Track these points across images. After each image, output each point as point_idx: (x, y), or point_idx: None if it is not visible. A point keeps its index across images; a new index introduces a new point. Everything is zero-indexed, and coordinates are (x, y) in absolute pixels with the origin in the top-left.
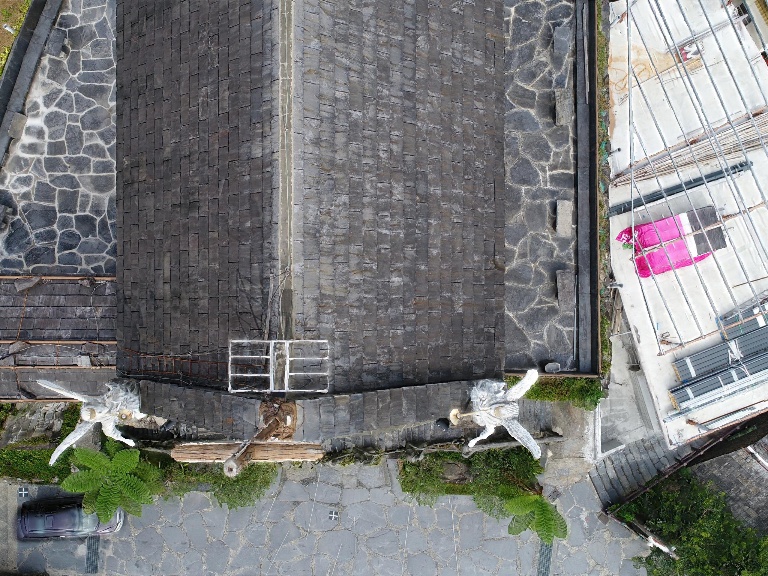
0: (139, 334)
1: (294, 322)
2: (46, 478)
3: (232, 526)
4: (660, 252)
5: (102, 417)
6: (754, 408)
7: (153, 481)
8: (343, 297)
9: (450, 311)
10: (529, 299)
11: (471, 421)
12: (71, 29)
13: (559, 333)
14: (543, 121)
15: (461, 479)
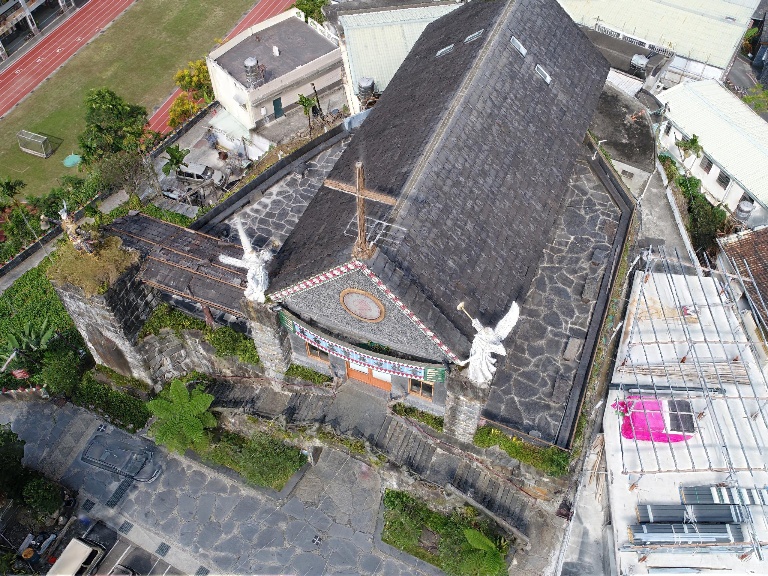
0: (284, 264)
1: (390, 234)
2: (125, 422)
3: (234, 515)
4: (641, 416)
5: (253, 262)
6: (701, 570)
7: (205, 437)
8: (419, 245)
9: (476, 306)
10: (532, 393)
11: (466, 377)
12: (312, 169)
13: (548, 423)
14: (575, 297)
15: (433, 547)
